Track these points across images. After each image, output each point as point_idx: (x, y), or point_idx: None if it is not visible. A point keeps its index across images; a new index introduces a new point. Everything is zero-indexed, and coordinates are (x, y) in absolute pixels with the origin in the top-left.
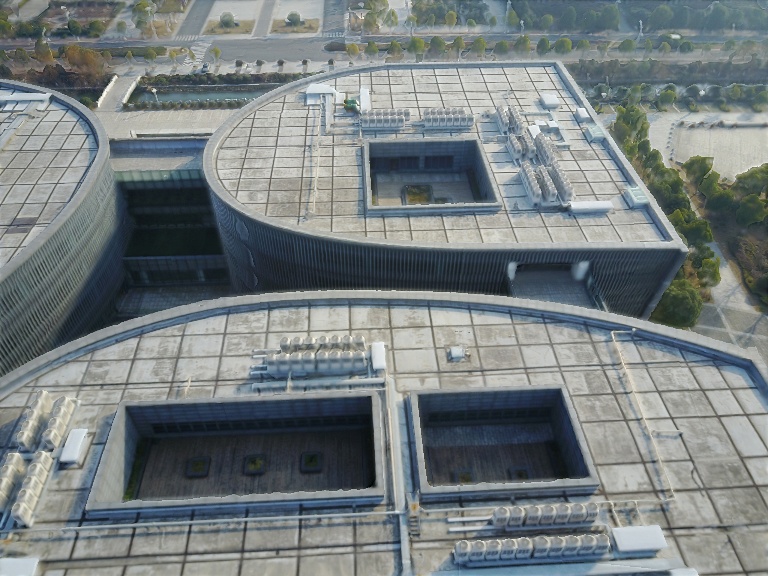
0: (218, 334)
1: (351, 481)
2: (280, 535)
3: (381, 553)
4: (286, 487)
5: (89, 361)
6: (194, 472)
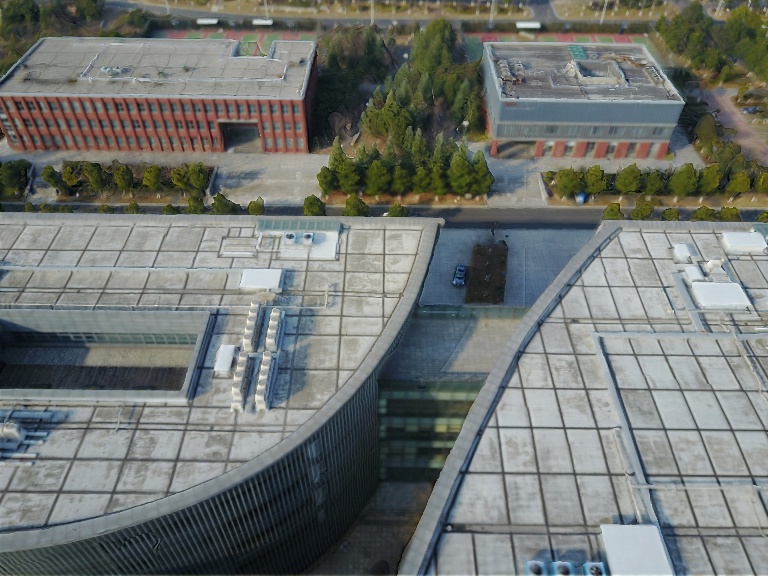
0: (68, 492)
1: (10, 377)
2: (72, 299)
3: (7, 286)
4: (68, 375)
5: (228, 461)
6: (145, 388)
